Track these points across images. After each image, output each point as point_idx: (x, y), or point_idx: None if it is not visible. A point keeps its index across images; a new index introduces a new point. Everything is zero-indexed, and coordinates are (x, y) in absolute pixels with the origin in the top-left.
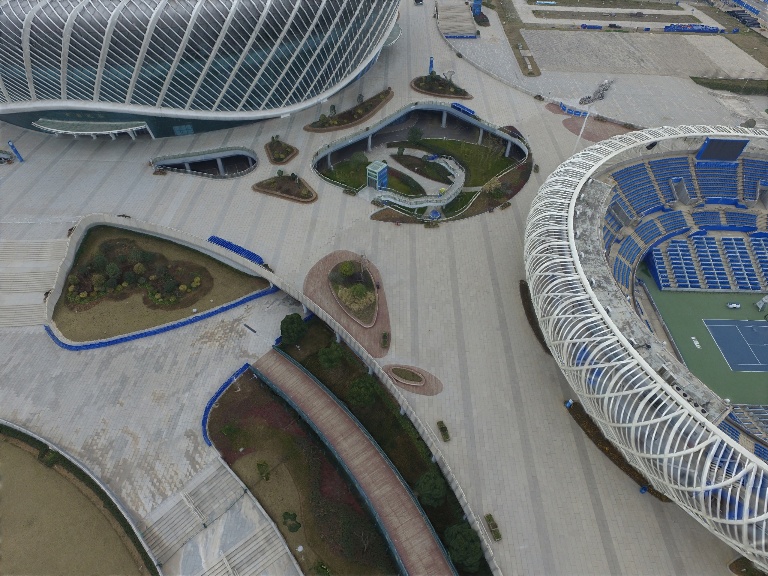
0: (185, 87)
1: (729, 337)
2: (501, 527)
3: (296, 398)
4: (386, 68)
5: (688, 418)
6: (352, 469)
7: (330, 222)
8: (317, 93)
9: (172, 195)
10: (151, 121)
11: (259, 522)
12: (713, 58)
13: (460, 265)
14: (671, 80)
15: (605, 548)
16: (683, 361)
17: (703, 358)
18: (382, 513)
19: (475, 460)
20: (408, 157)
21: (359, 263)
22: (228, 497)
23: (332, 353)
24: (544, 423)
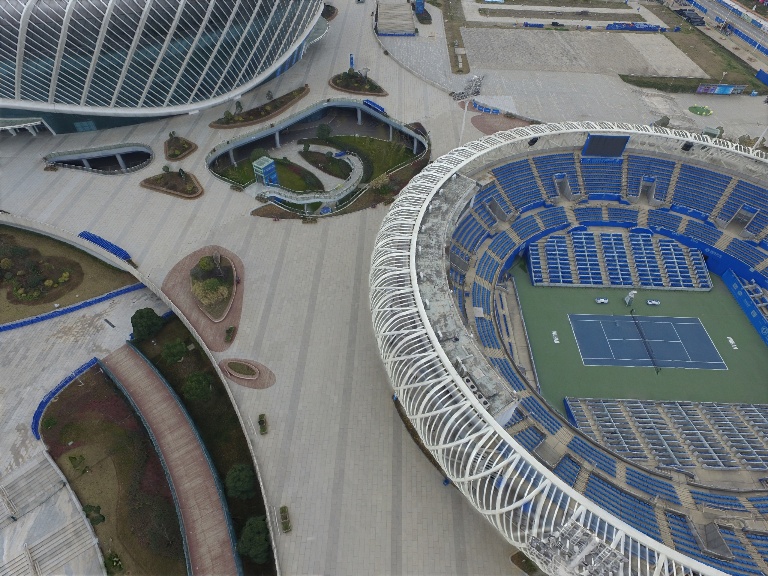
0: (75, 83)
1: (590, 332)
2: (294, 519)
3: (135, 392)
4: (309, 65)
5: (468, 409)
6: (169, 462)
7: (209, 218)
8: (228, 90)
9: (57, 191)
10: (48, 117)
11: (71, 515)
12: (647, 56)
13: (327, 260)
14: (599, 78)
15: (392, 539)
16: (531, 355)
17: (558, 352)
18: (185, 505)
19: (287, 453)
20: (315, 154)
21: (225, 258)
22: (46, 490)
23: (175, 347)
24: (367, 416)
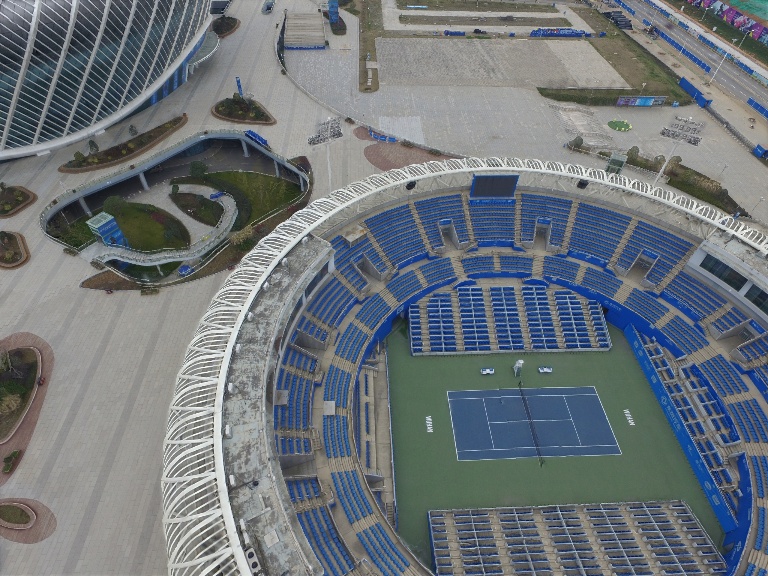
0: None
1: (470, 414)
2: None
3: None
4: (193, 89)
5: None
6: None
7: (27, 293)
8: (85, 125)
9: None
10: None
11: None
12: (568, 66)
13: (160, 345)
14: (516, 92)
15: None
16: (391, 457)
17: (430, 445)
18: None
19: None
20: (187, 196)
21: (32, 350)
22: None
23: None
24: (163, 574)
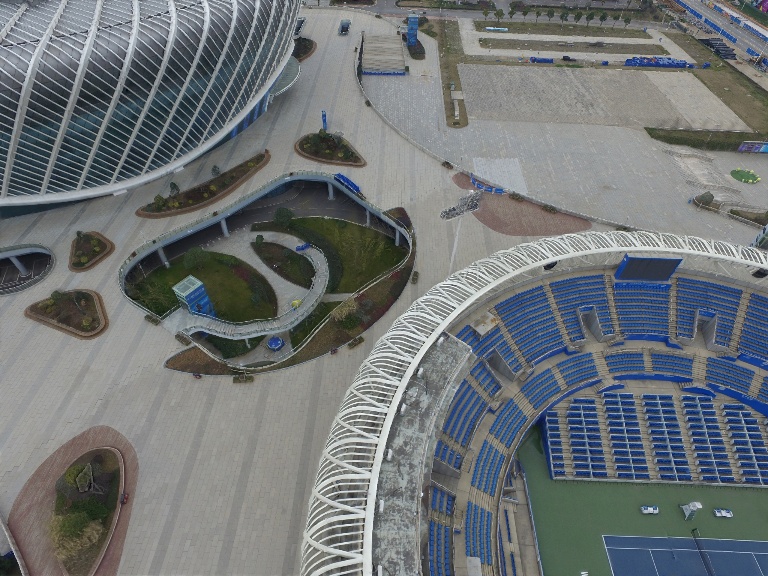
0: None
1: (636, 573)
2: None
3: None
4: (274, 121)
5: None
6: None
7: (106, 372)
8: (165, 162)
9: None
10: None
11: None
12: (675, 102)
13: (260, 455)
14: (621, 132)
15: None
16: None
17: None
18: None
19: None
20: (271, 247)
21: (113, 453)
22: None
23: None
24: None
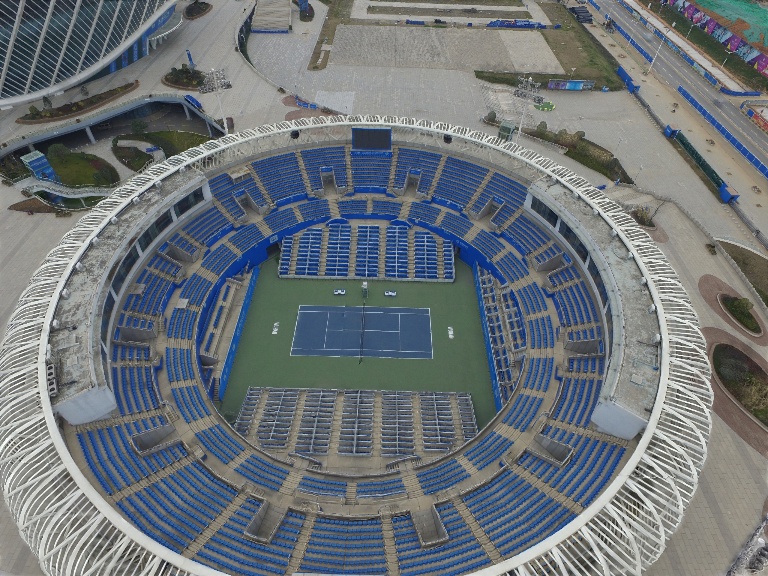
0: None
1: (313, 323)
2: None
3: None
4: (152, 61)
5: (32, 396)
6: None
7: None
8: (45, 85)
9: None
10: None
11: None
12: (512, 53)
13: None
14: (453, 74)
15: None
16: (229, 346)
17: (271, 343)
18: None
19: None
20: (126, 149)
21: None
22: None
23: None
24: None
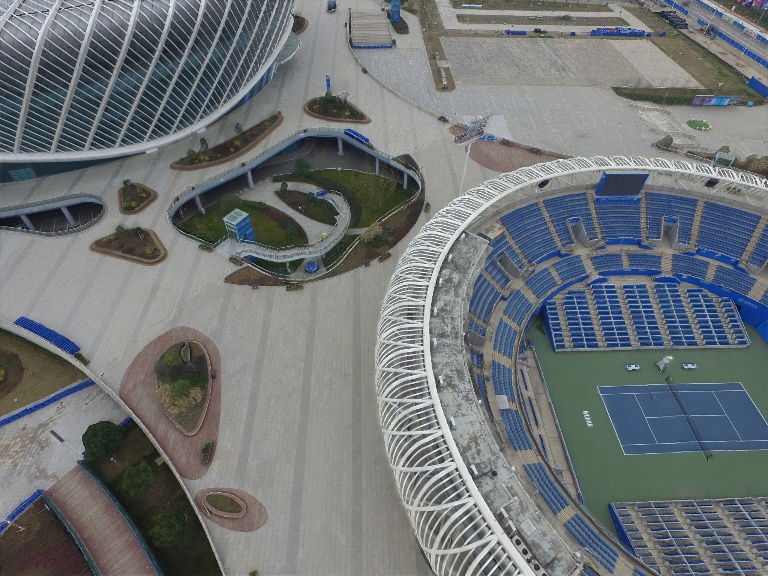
0: (4, 129)
1: (625, 409)
2: None
3: (91, 538)
4: (281, 88)
5: None
6: None
7: (175, 289)
8: (190, 123)
9: None
10: None
11: None
12: (637, 65)
13: (319, 339)
14: (591, 91)
15: None
16: (566, 451)
17: (594, 439)
18: None
19: None
20: (294, 194)
21: (197, 344)
22: None
23: (139, 475)
24: (384, 562)
